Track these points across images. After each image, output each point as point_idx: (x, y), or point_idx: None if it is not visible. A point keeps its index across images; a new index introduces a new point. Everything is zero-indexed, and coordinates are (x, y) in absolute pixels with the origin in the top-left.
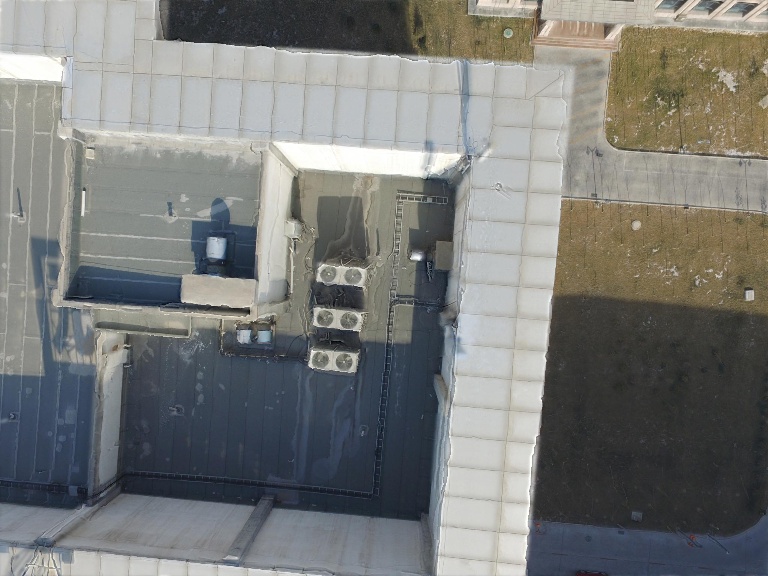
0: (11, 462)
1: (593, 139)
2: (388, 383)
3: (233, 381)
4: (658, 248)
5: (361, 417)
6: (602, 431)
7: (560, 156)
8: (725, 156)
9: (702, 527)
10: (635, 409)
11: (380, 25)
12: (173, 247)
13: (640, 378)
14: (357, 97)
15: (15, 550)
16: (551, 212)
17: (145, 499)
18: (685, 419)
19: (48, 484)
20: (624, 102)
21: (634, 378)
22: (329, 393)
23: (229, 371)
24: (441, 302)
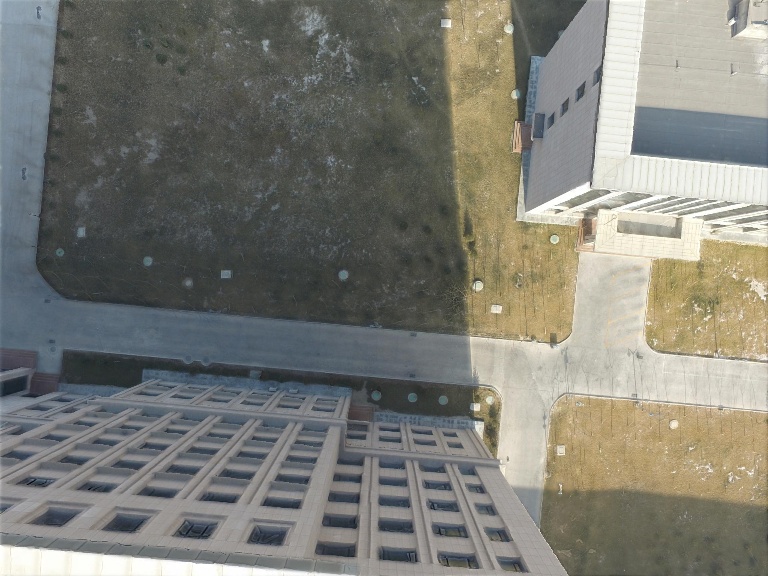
0: None
1: (634, 342)
2: None
3: None
4: (694, 446)
5: None
6: None
7: None
8: (757, 361)
9: None
10: None
11: (431, 227)
12: None
13: (676, 570)
14: None
15: None
16: None
17: None
18: None
19: None
20: (663, 307)
21: (671, 570)
22: None
23: None
24: None
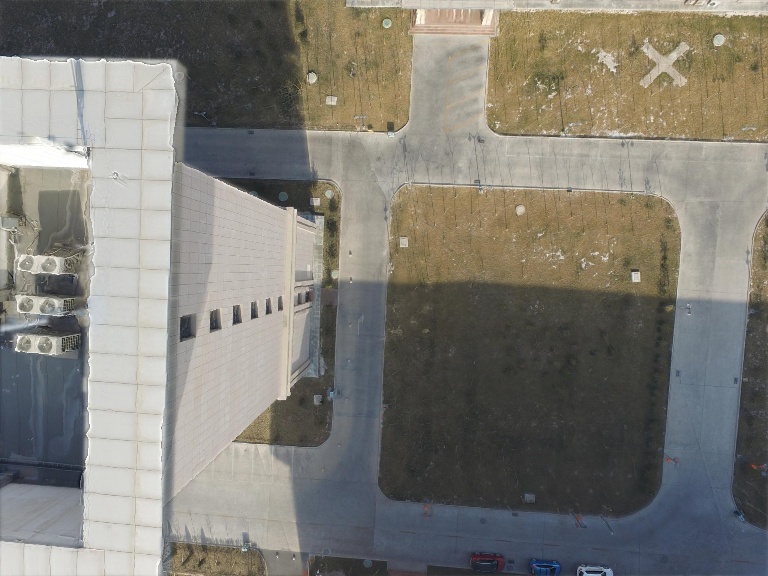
0: None
1: (474, 125)
2: None
3: None
4: (543, 232)
5: None
6: (493, 415)
7: (169, 145)
8: (607, 137)
9: (595, 508)
10: (525, 393)
11: (262, 21)
12: None
13: (529, 362)
14: None
15: None
16: (163, 198)
17: None
18: (575, 402)
19: None
20: (504, 87)
21: (523, 362)
22: (58, 375)
23: None
24: None
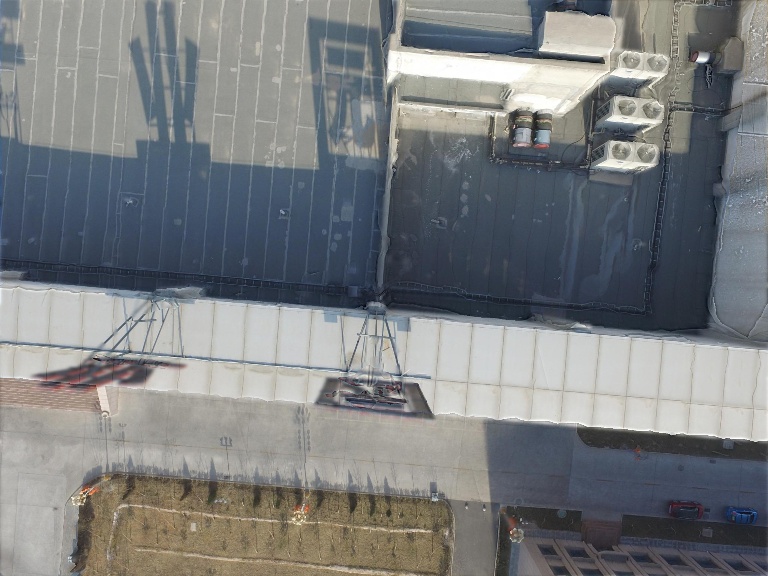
0: (280, 263)
1: None
2: (665, 193)
3: (500, 192)
4: (751, 178)
5: (634, 230)
6: None
7: None
8: None
9: None
10: None
11: None
12: (509, 0)
13: (732, 307)
14: None
15: (343, 319)
16: None
17: (418, 308)
18: None
19: (323, 285)
20: None
21: (726, 307)
22: (601, 205)
23: (496, 181)
24: (726, 105)
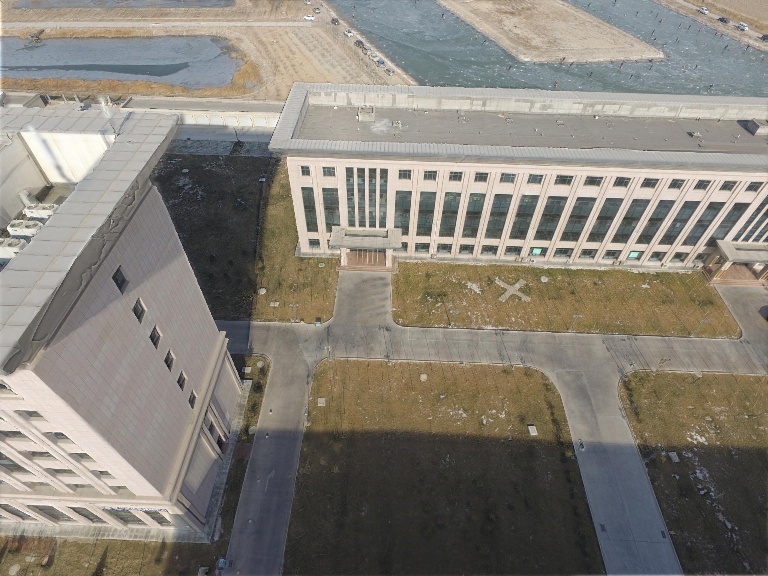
0: None
1: (383, 321)
2: None
3: None
4: (445, 394)
5: None
6: None
7: None
8: (483, 329)
9: None
10: (447, 558)
11: (234, 262)
12: None
13: (447, 519)
14: (73, 119)
15: None
16: (152, 148)
17: None
18: (505, 568)
19: None
20: (404, 300)
21: (441, 520)
22: None
23: None
24: None
